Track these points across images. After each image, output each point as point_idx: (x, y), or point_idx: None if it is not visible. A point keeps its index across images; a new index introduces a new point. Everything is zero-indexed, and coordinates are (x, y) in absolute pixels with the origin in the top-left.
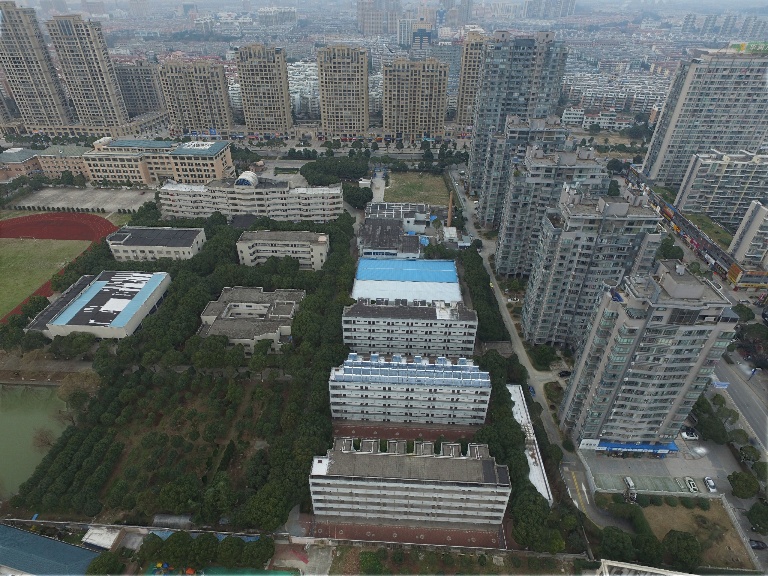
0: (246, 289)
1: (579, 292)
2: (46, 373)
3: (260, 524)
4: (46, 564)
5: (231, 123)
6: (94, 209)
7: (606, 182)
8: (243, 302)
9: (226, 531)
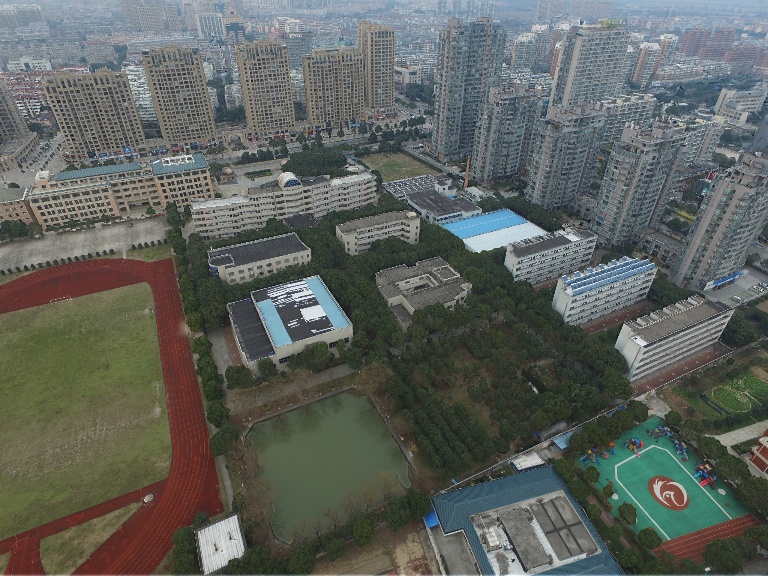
0: (393, 270)
1: (642, 198)
2: (294, 395)
3: (624, 395)
4: (534, 486)
5: (144, 138)
6: (94, 253)
7: (605, 124)
8: (404, 279)
9: (589, 419)
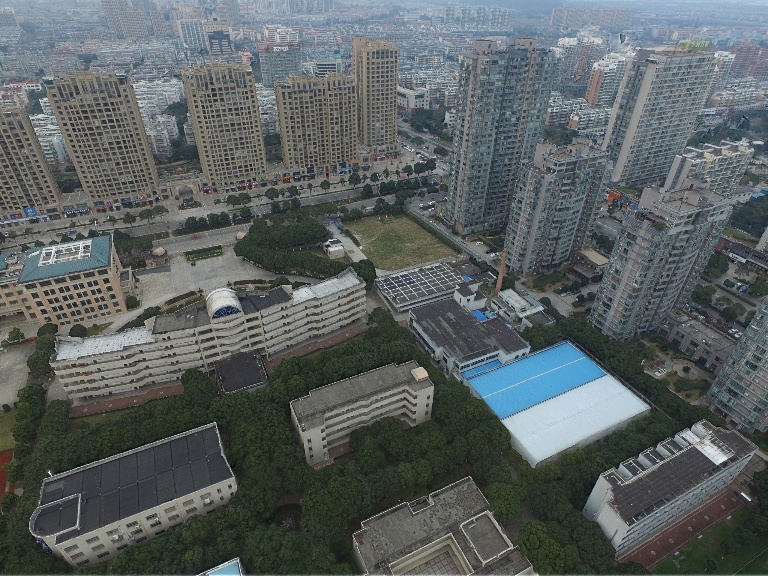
0: (385, 518)
1: None
2: None
3: None
4: None
5: (57, 193)
6: None
7: None
8: (406, 550)
9: None
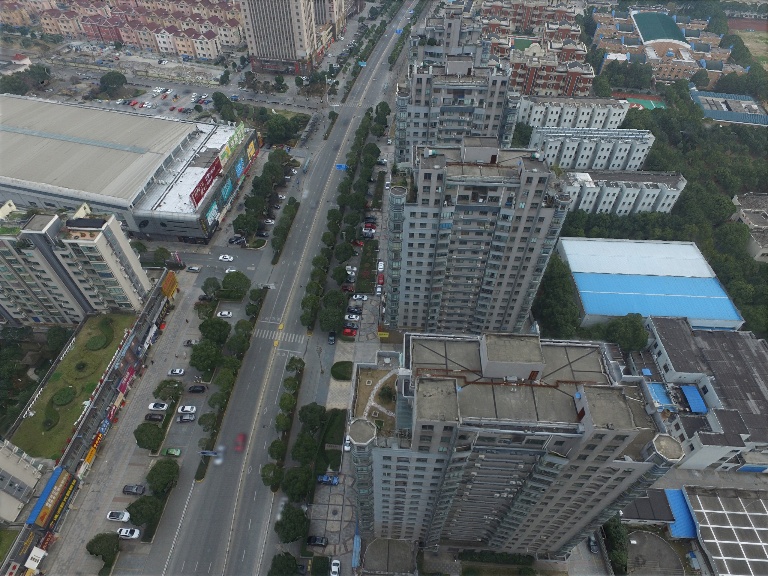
0: None
1: None
2: None
3: None
4: None
5: None
6: None
7: None
8: None
9: None
